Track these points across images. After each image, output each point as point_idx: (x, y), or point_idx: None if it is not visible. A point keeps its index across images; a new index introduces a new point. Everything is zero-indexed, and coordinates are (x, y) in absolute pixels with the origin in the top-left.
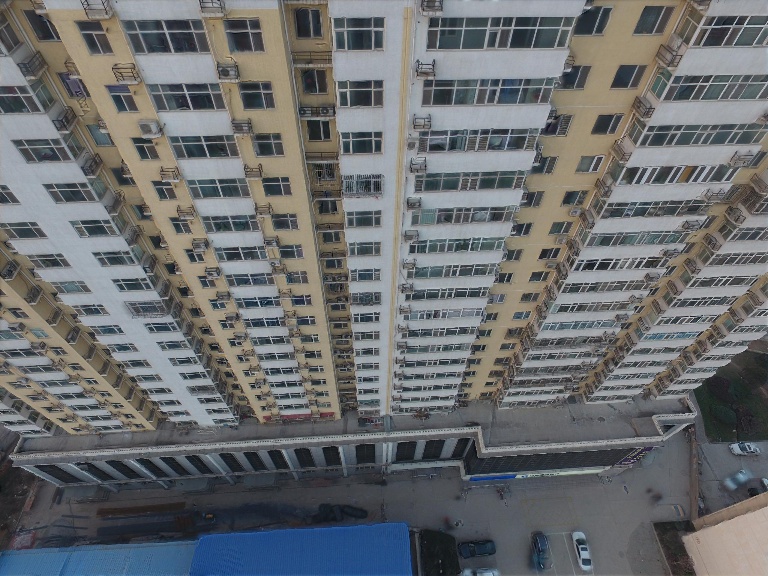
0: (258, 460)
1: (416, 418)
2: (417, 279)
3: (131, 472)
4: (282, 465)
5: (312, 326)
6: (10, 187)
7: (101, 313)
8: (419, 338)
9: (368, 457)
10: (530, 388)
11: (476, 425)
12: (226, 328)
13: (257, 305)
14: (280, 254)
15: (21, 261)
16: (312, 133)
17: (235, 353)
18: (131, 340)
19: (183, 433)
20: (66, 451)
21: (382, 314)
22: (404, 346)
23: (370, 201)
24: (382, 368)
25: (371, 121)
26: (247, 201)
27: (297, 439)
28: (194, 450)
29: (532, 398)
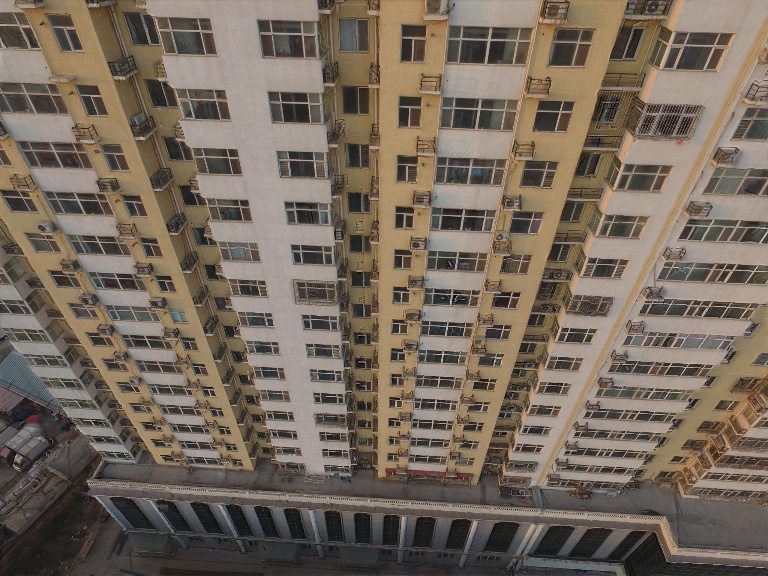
0: (366, 527)
1: (574, 495)
2: (670, 281)
3: (212, 523)
4: (391, 539)
5: (503, 341)
6: (229, 93)
7: (258, 294)
8: (630, 375)
9: (501, 543)
10: (740, 470)
11: (659, 514)
12: (396, 333)
13: (446, 302)
14: (510, 225)
15: (190, 216)
16: (616, 46)
17: (391, 371)
18: (278, 337)
19: (285, 479)
20: (151, 483)
21: (599, 332)
22: (609, 384)
23: (666, 149)
24: (562, 415)
25: (727, 14)
26: (505, 137)
27: (425, 503)
28: (298, 502)
29: (735, 486)
